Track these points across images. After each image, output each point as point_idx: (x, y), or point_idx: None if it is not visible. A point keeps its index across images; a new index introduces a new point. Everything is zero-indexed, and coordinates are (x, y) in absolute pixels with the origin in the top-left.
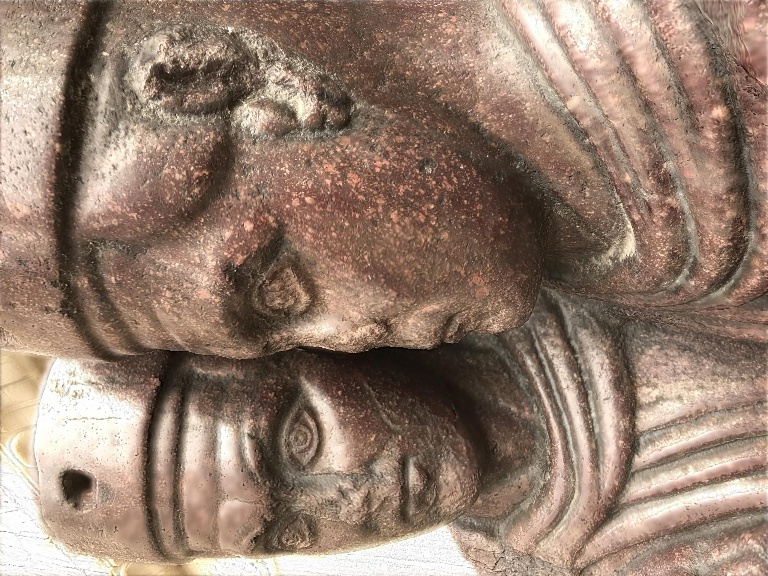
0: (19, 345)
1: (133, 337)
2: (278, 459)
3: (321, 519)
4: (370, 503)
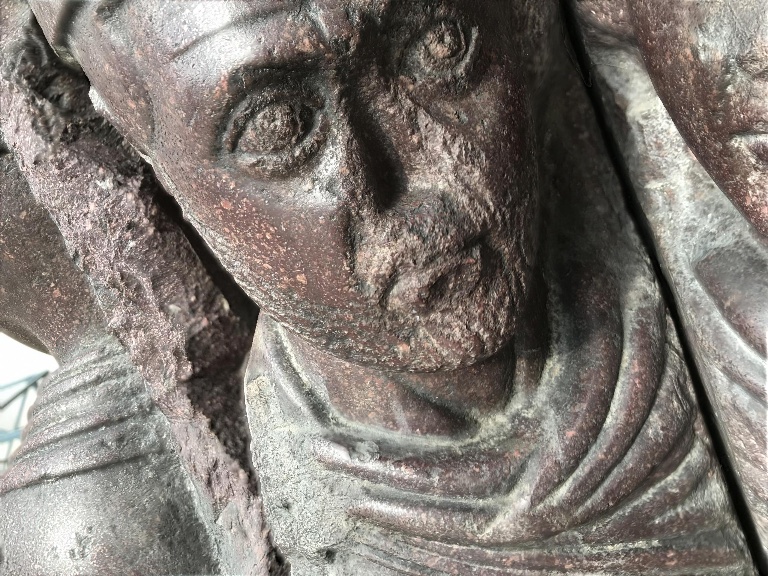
0: None
1: None
2: None
3: None
4: None
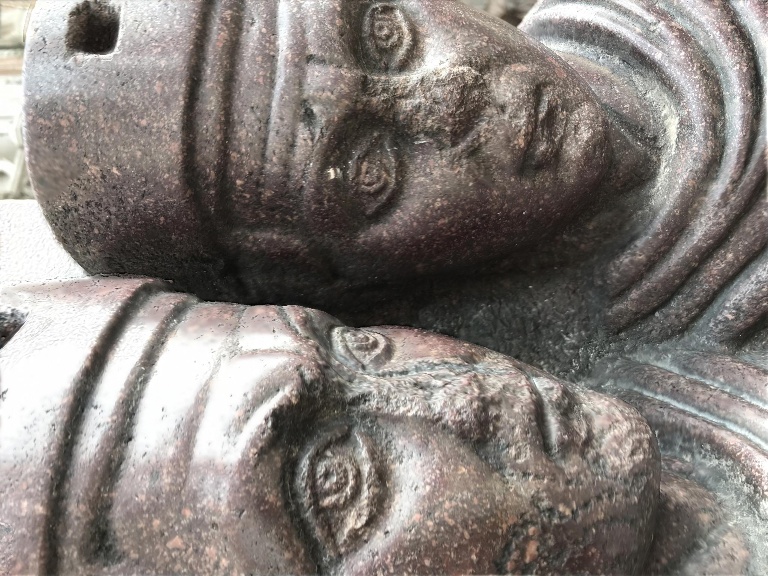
0: (109, 57)
1: (236, 50)
2: (326, 343)
3: (394, 431)
4: (481, 387)
